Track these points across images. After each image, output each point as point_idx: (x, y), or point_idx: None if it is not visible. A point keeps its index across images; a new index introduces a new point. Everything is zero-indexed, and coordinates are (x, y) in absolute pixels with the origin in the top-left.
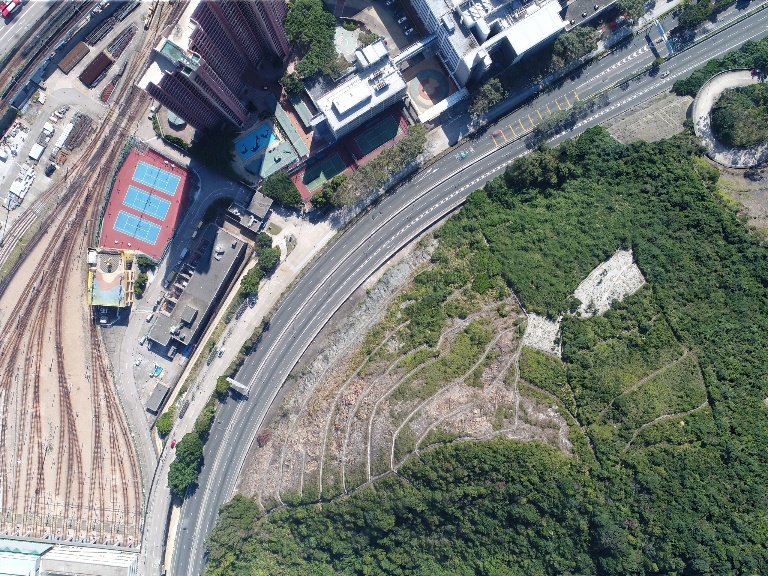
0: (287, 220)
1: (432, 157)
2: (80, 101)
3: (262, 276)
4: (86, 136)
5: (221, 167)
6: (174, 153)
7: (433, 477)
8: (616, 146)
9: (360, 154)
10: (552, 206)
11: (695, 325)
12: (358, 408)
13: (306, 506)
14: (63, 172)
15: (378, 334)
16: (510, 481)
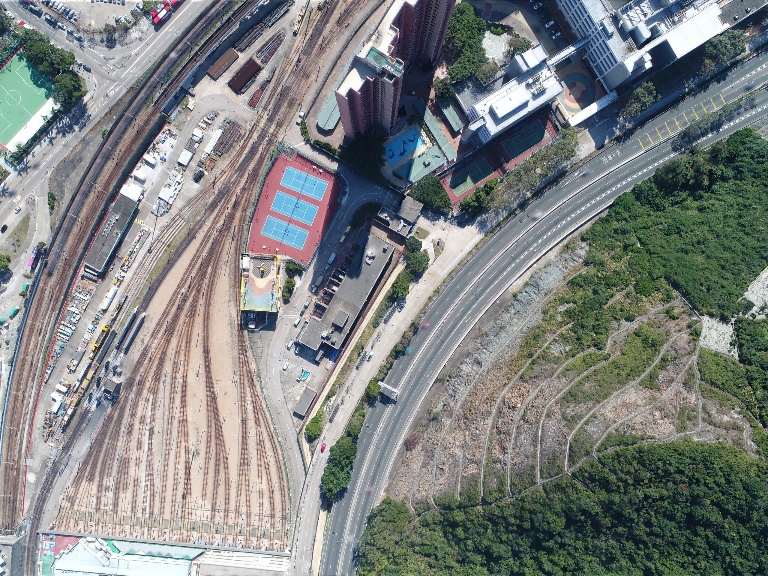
0: (435, 224)
1: (579, 160)
2: (229, 107)
3: (410, 280)
4: (234, 142)
5: (373, 172)
6: (322, 158)
7: (613, 479)
8: None
9: (507, 158)
10: (706, 208)
11: None
12: (525, 411)
13: (465, 509)
14: (211, 178)
15: (539, 337)
16: (694, 483)
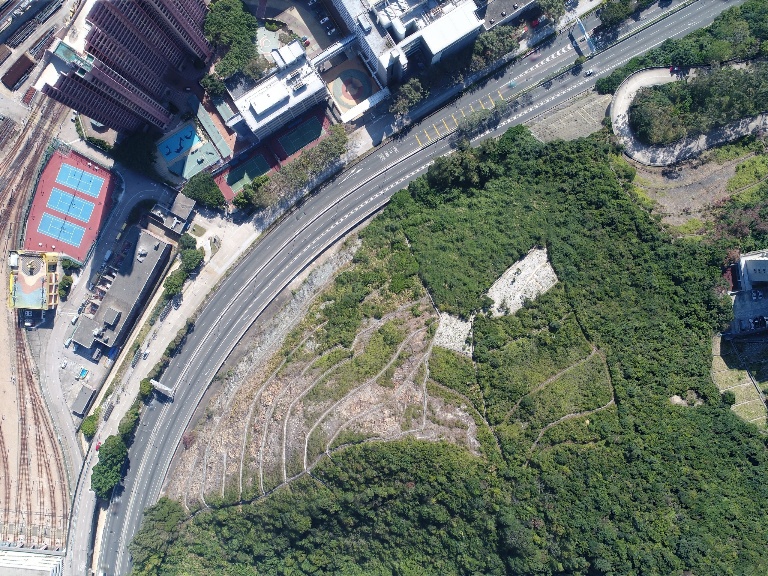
0: (211, 221)
1: (356, 157)
2: (2, 104)
3: (186, 278)
4: (9, 139)
5: (142, 169)
6: (97, 155)
7: (344, 478)
8: (536, 145)
9: (284, 155)
10: (473, 205)
11: (604, 323)
12: (274, 409)
13: (227, 508)
14: None
15: (297, 335)
16: (419, 481)
